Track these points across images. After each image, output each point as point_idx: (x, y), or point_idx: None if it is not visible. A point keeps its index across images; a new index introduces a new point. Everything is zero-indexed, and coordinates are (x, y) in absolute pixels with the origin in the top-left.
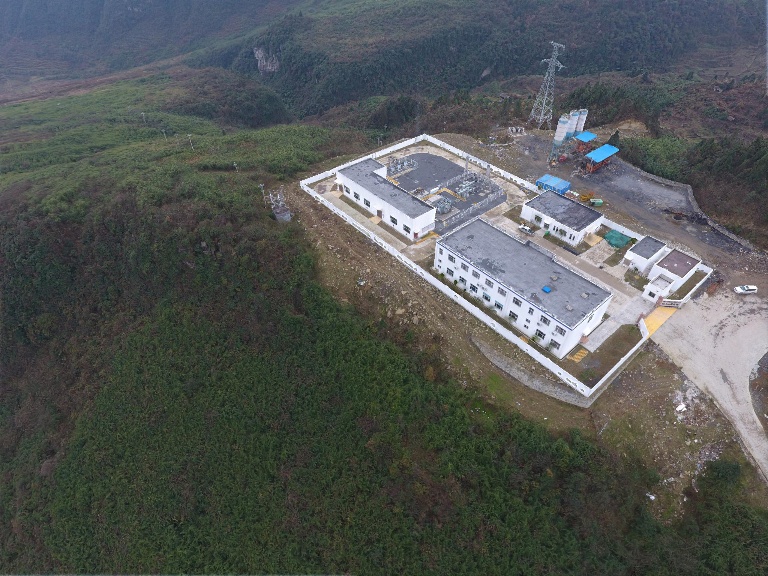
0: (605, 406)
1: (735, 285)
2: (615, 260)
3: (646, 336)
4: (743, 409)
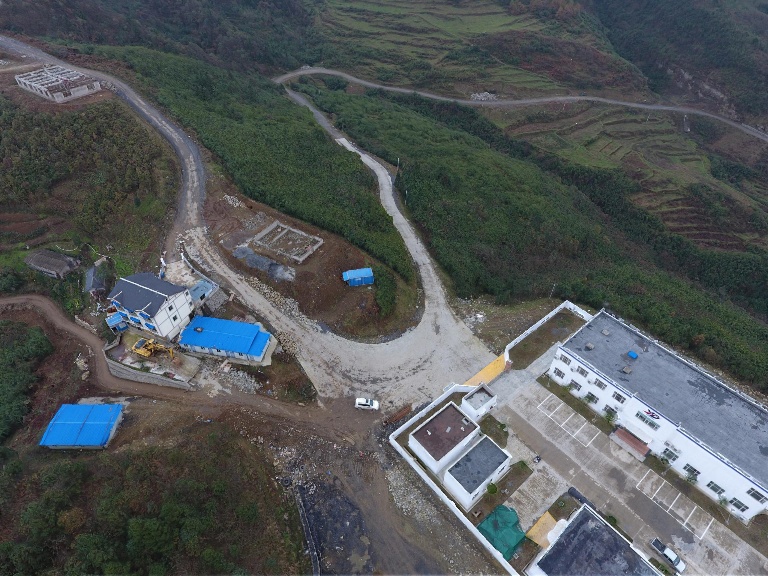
0: (544, 314)
1: (371, 418)
2: (516, 474)
3: (510, 343)
4: (434, 309)
